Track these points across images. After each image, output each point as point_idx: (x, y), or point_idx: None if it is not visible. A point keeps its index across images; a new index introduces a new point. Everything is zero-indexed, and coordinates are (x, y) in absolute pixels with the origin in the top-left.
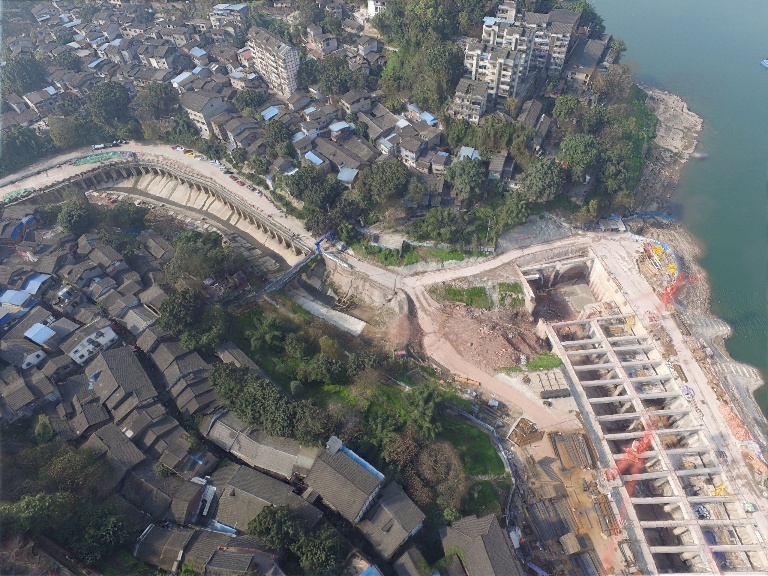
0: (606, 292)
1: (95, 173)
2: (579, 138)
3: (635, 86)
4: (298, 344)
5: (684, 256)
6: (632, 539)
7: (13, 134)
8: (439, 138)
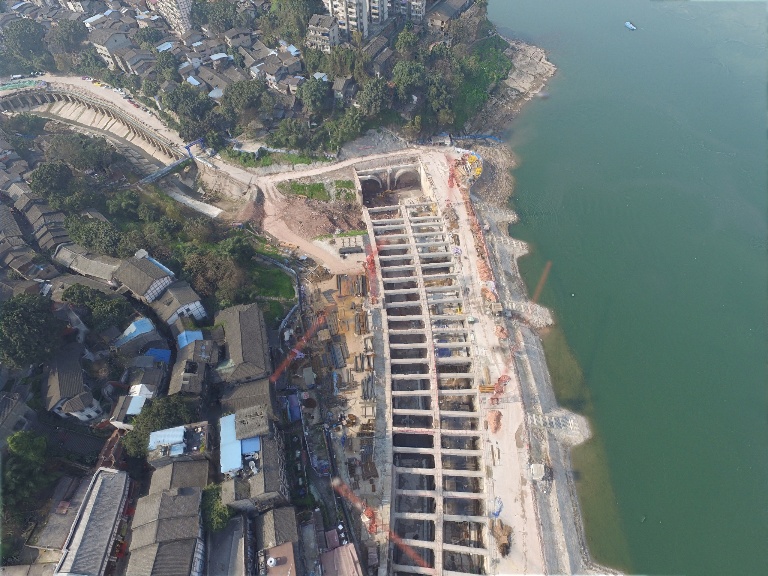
0: (427, 191)
1: (11, 98)
2: (408, 64)
3: (497, 37)
4: (149, 211)
5: (498, 166)
6: (377, 338)
7: None
8: (300, 66)
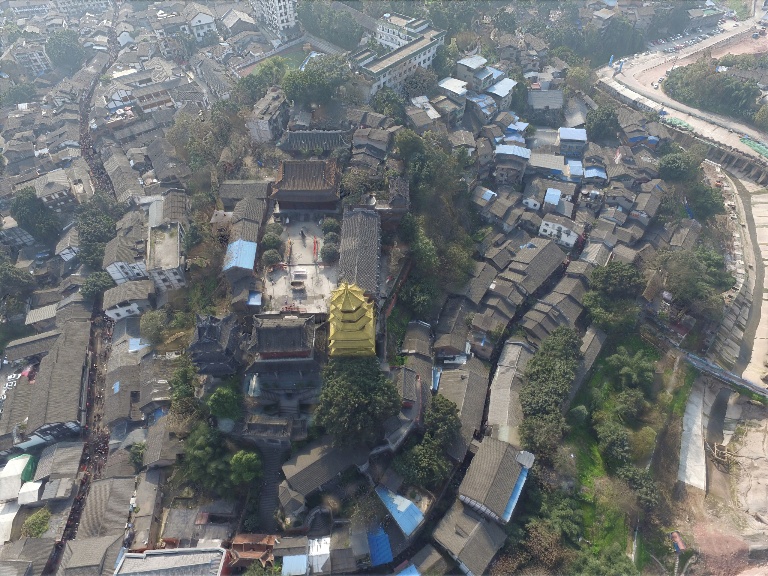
0: None
1: (743, 158)
2: None
3: None
4: (632, 404)
5: None
6: None
7: (742, 85)
8: None
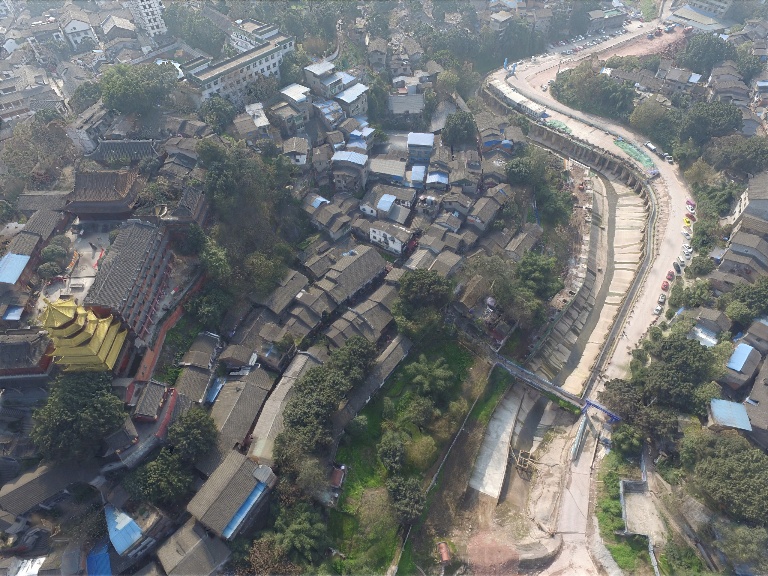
0: None
1: (614, 160)
2: None
3: None
4: (421, 413)
5: None
6: None
7: (619, 87)
8: None
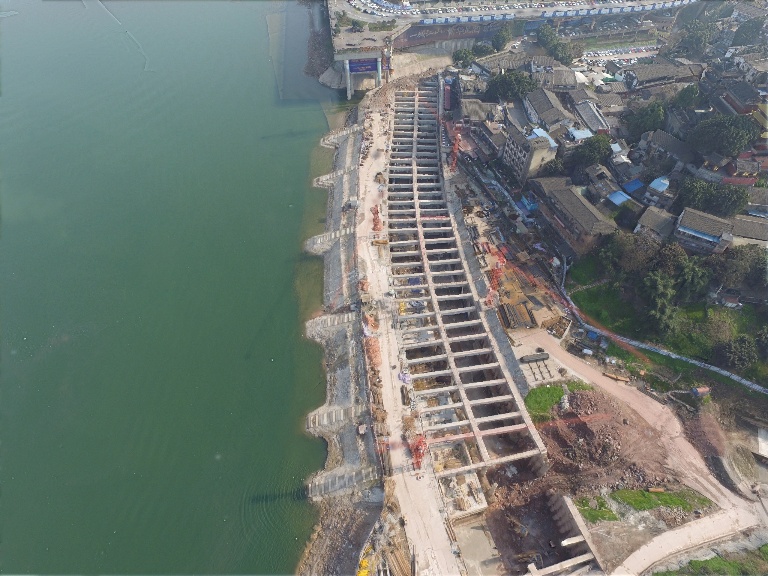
0: None
1: None
2: None
3: None
4: None
5: None
6: (477, 271)
7: None
8: None
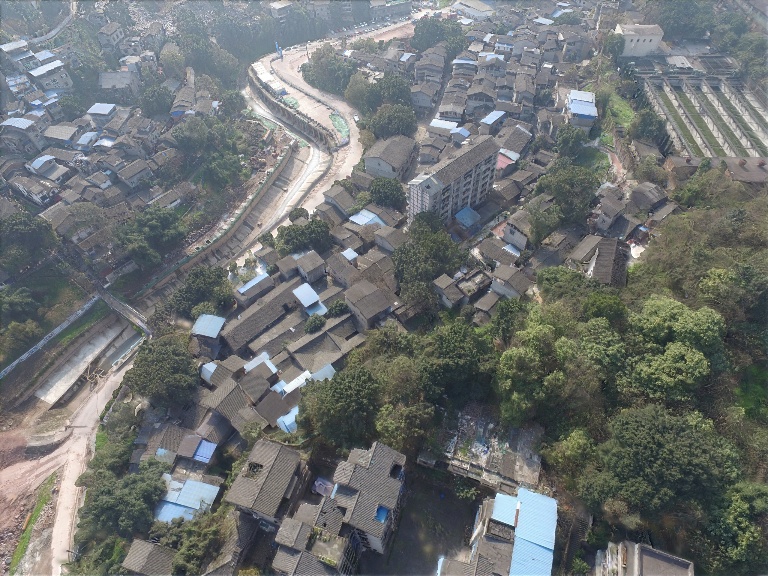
0: None
1: (321, 131)
2: None
3: None
4: None
5: None
6: None
7: None
8: None
